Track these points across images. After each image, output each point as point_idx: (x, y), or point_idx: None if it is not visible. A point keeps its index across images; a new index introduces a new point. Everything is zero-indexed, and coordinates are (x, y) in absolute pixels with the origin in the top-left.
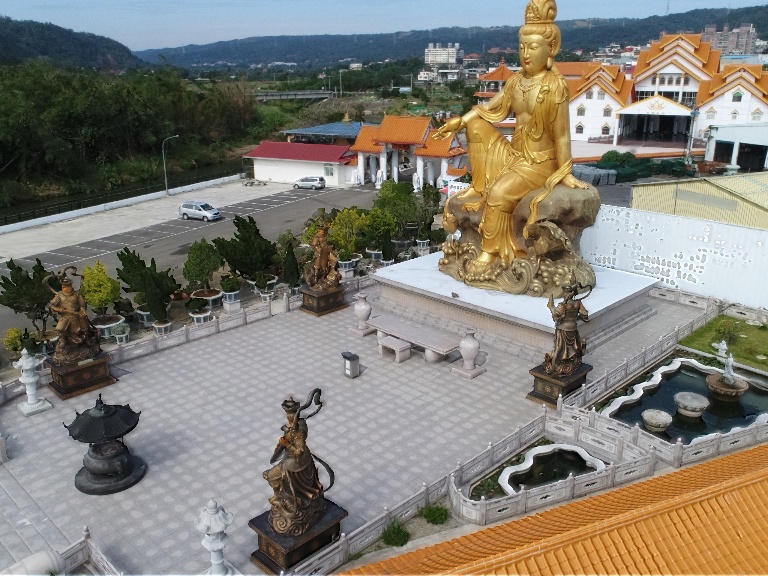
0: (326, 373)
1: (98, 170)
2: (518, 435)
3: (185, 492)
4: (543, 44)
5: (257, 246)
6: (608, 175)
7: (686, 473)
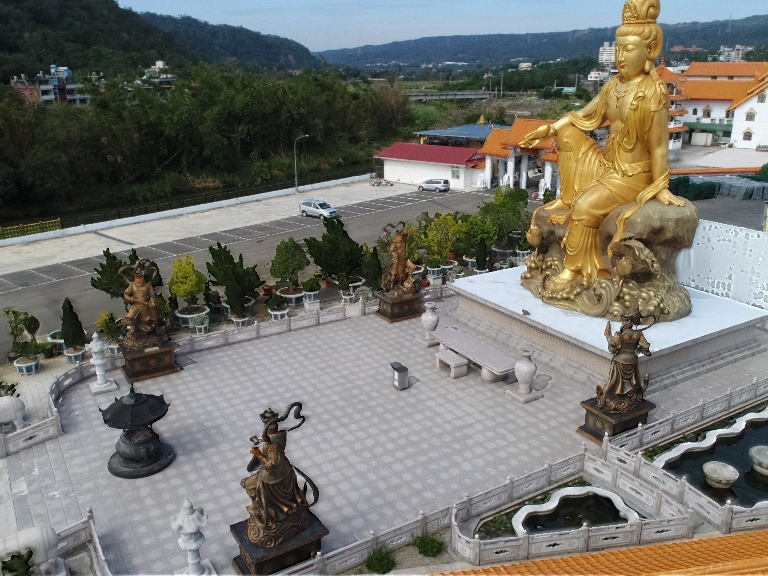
0: (376, 382)
1: (251, 165)
2: (546, 472)
3: (199, 486)
4: (640, 46)
5: (342, 248)
6: (763, 188)
7: (696, 545)
